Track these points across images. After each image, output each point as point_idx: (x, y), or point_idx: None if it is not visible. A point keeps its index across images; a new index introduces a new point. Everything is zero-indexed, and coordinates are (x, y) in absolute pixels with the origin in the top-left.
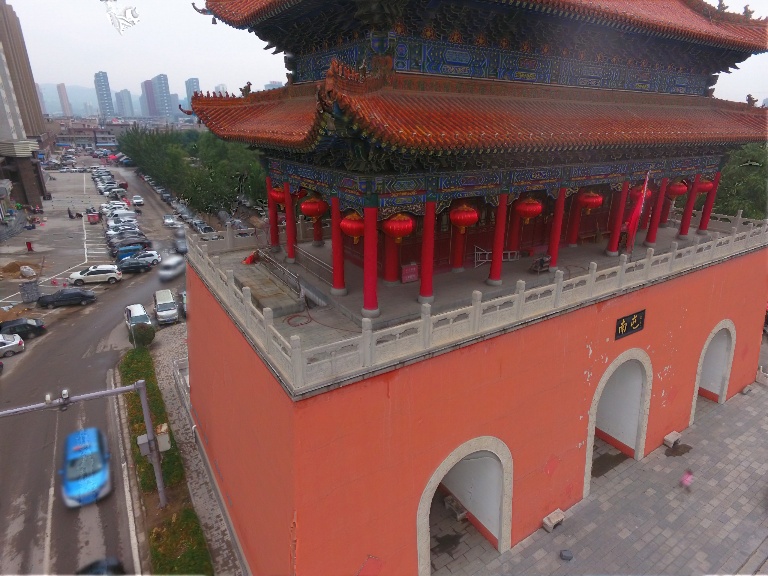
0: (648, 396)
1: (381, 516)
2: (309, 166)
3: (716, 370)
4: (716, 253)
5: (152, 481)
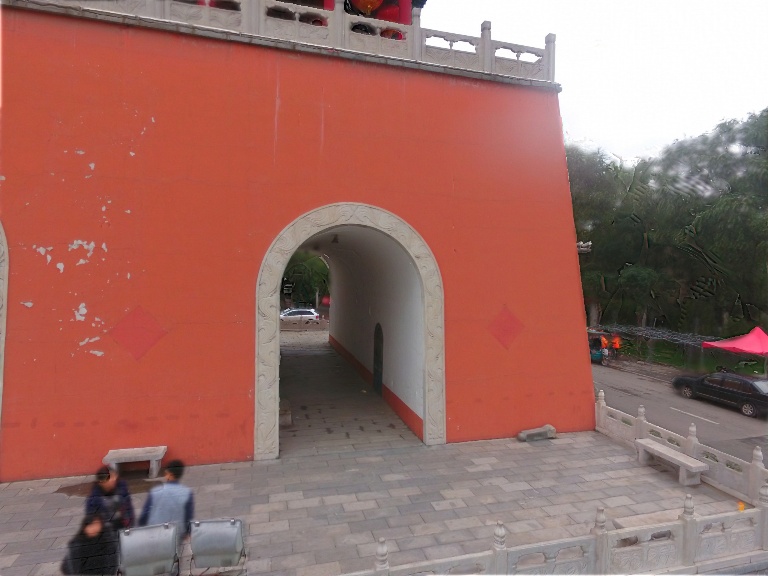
0: None
1: None
2: None
3: (417, 357)
4: (277, 32)
5: None
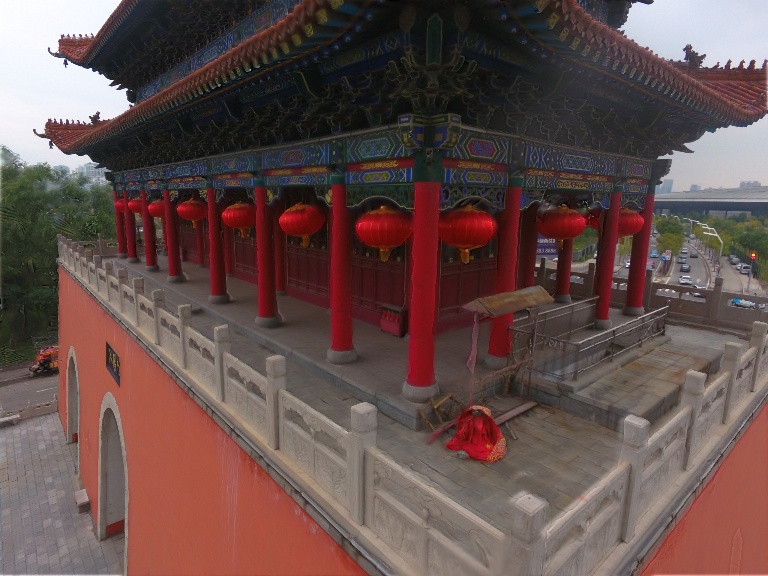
0: None
1: None
2: (590, 150)
3: None
4: None
5: None
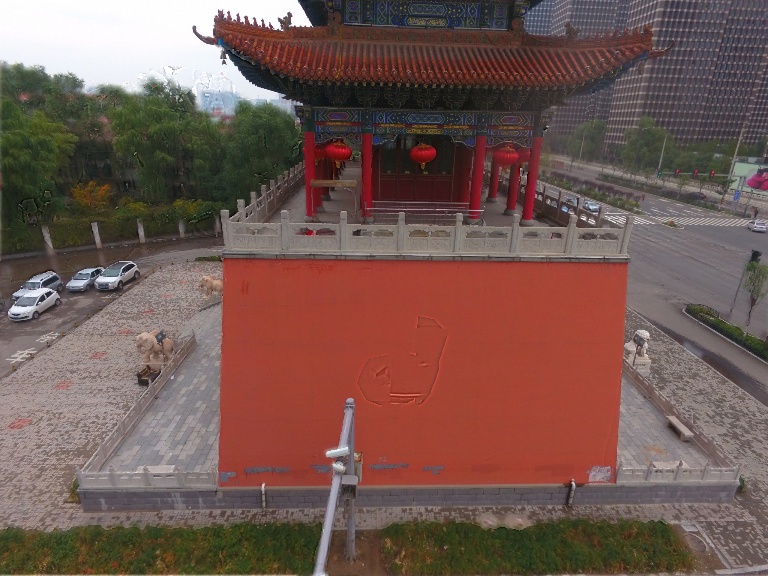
0: None
1: None
2: (437, 110)
3: None
4: None
5: (312, 555)
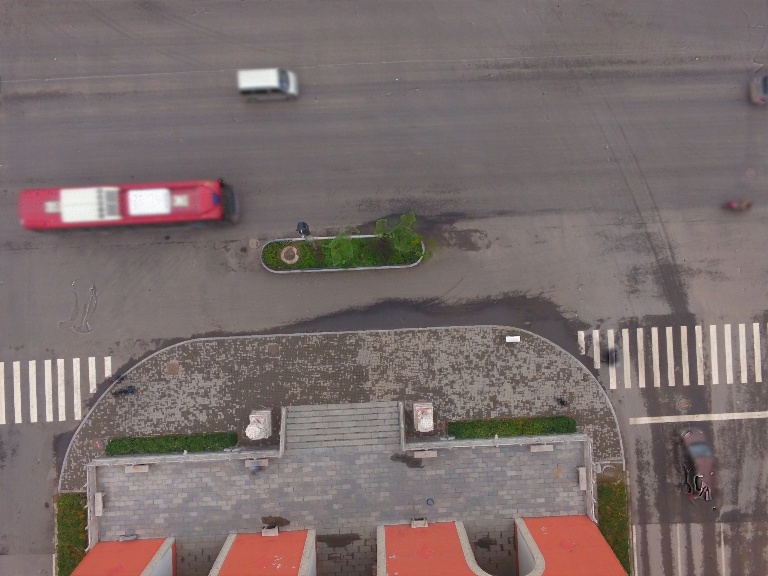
0: (303, 569)
1: (572, 567)
2: None
3: (161, 568)
4: None
5: None
